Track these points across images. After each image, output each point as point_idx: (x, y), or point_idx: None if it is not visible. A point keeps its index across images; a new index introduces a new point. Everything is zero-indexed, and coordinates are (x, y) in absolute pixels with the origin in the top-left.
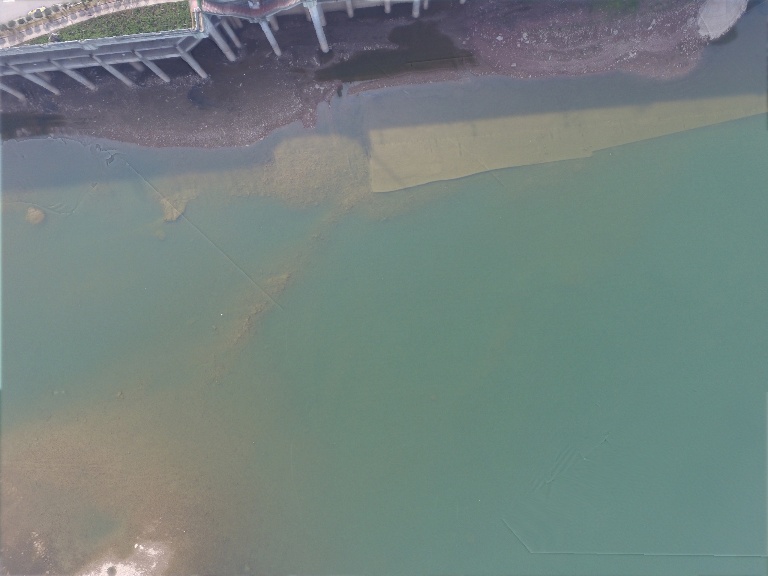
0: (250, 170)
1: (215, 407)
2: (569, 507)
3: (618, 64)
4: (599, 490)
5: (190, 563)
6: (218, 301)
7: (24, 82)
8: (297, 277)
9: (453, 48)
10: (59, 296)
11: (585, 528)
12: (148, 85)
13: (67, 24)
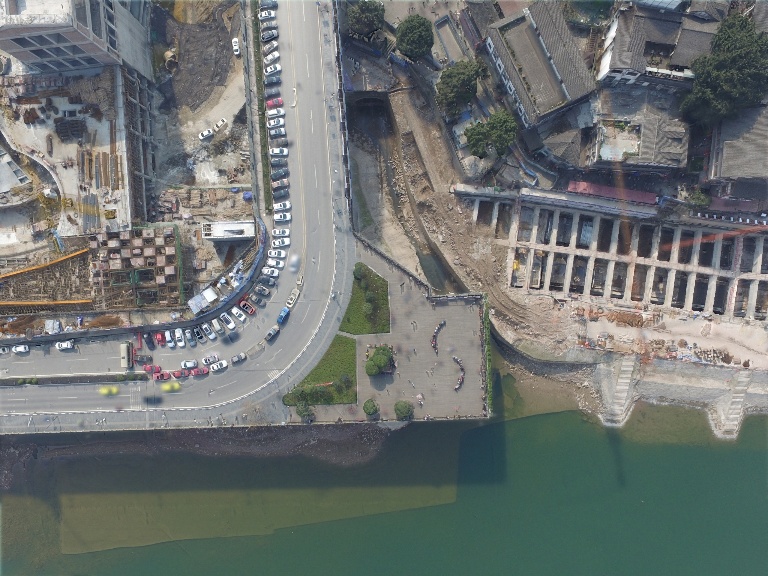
0: None
1: None
2: None
3: (300, 449)
4: None
5: None
6: None
7: None
8: None
9: None
10: None
11: None
12: None
13: None
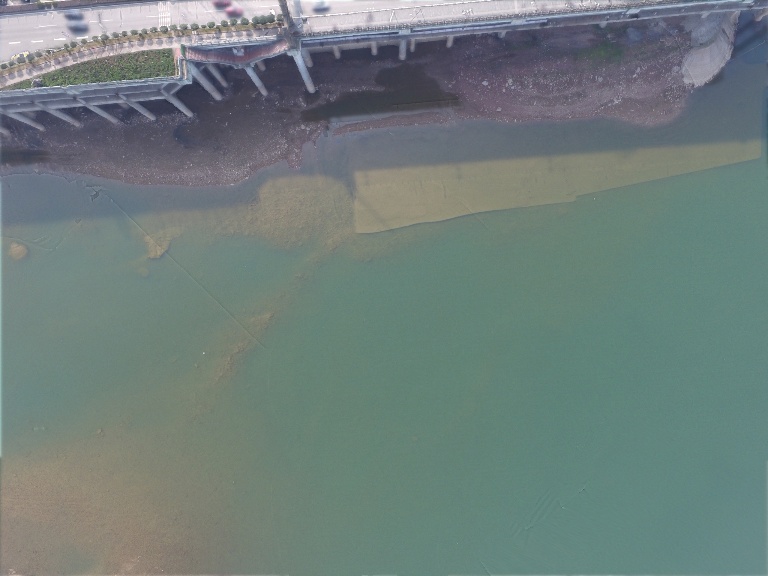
0: (235, 209)
1: (196, 446)
2: (547, 555)
3: (603, 110)
4: (576, 540)
5: None
6: (200, 339)
7: (9, 117)
8: (280, 317)
9: (439, 91)
10: (41, 331)
11: None
12: (134, 123)
13: (50, 69)
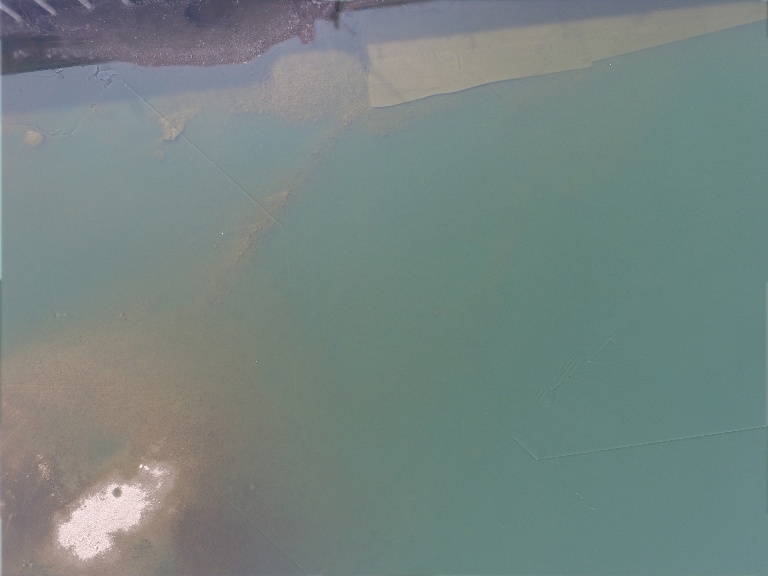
0: (248, 88)
1: (217, 326)
2: (574, 411)
3: None
4: (604, 390)
5: (195, 483)
6: (219, 220)
7: (20, 3)
8: (297, 194)
9: None
10: (59, 221)
11: (591, 428)
12: (145, 3)
13: None
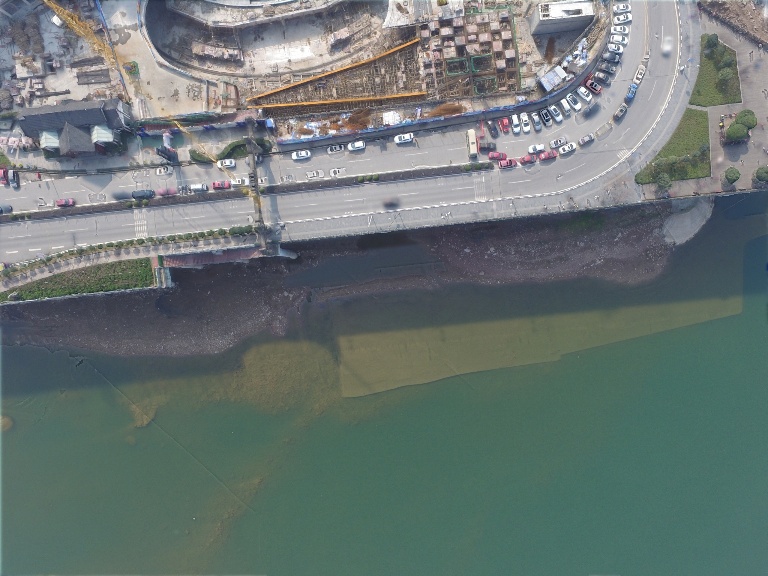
0: (220, 376)
1: None
2: None
3: (585, 270)
4: None
5: None
6: (190, 505)
7: None
8: (269, 481)
9: (422, 254)
10: (30, 496)
11: None
12: (115, 294)
13: (26, 281)
